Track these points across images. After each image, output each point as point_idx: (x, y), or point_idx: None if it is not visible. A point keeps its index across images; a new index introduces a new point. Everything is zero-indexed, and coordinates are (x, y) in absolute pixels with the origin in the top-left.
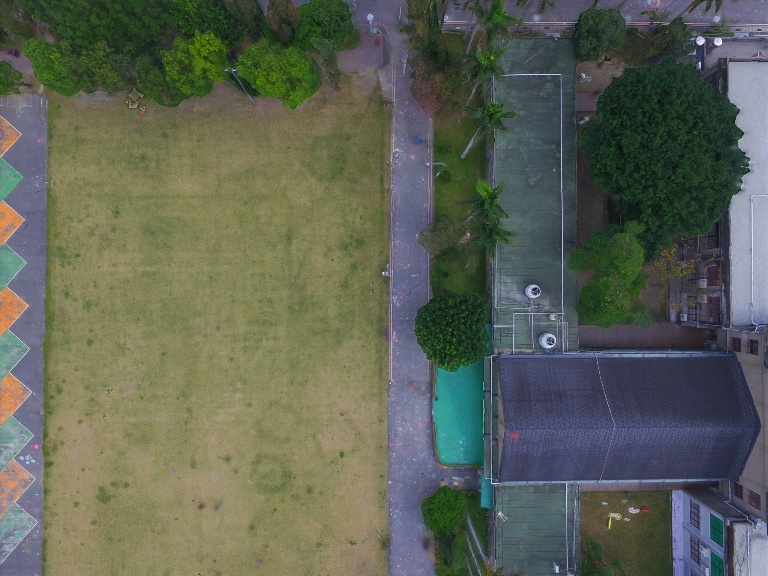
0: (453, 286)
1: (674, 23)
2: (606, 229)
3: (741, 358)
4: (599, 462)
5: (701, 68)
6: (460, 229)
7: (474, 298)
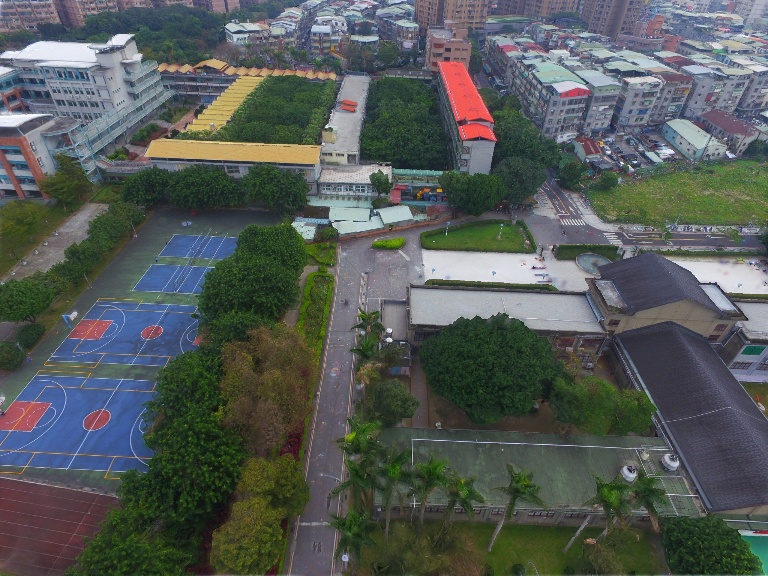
0: (639, 568)
1: (382, 353)
2: (555, 408)
3: (620, 331)
4: (759, 423)
5: (405, 342)
6: (584, 551)
7: (671, 531)
